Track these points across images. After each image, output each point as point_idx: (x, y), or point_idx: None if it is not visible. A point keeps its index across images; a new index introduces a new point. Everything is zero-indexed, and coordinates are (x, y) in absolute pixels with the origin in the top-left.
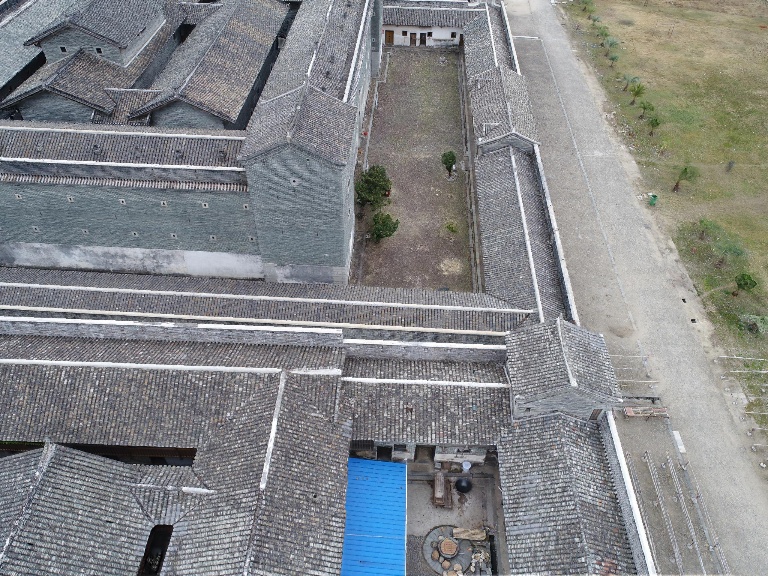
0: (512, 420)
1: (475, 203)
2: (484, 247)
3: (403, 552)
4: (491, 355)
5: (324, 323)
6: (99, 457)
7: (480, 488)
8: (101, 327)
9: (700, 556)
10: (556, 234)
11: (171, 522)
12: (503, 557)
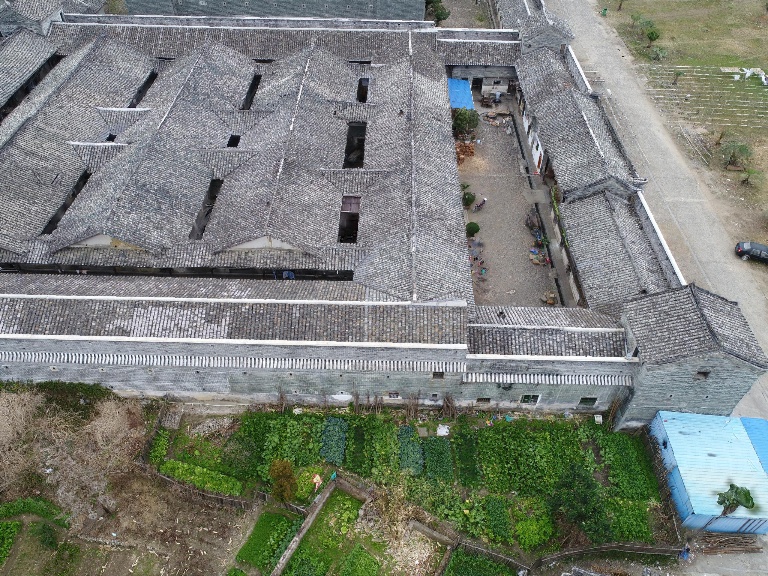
0: (522, 56)
1: (494, 14)
2: (502, 16)
3: (472, 101)
4: (510, 37)
5: None
6: (331, 52)
7: (505, 103)
8: (310, 23)
9: (614, 115)
10: (543, 4)
11: (367, 77)
12: (518, 119)
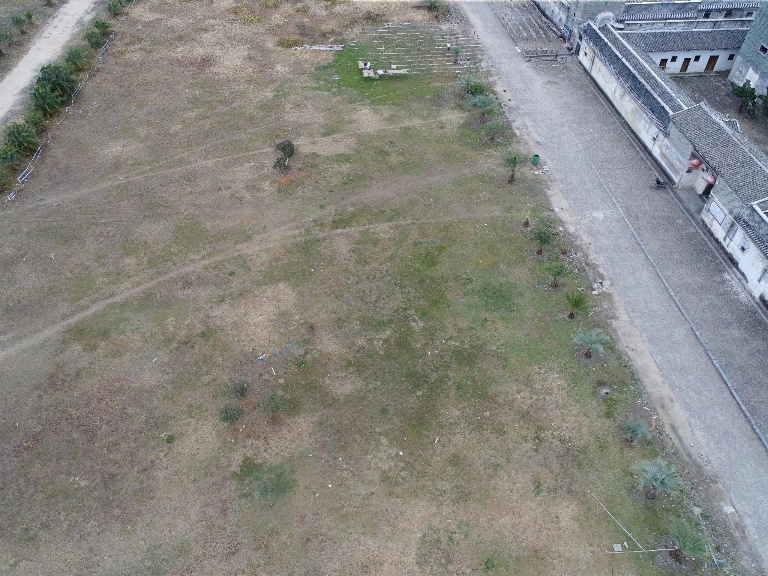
0: None
1: None
2: None
3: None
4: None
5: (718, 19)
6: None
7: None
8: None
9: None
10: None
11: None
12: None
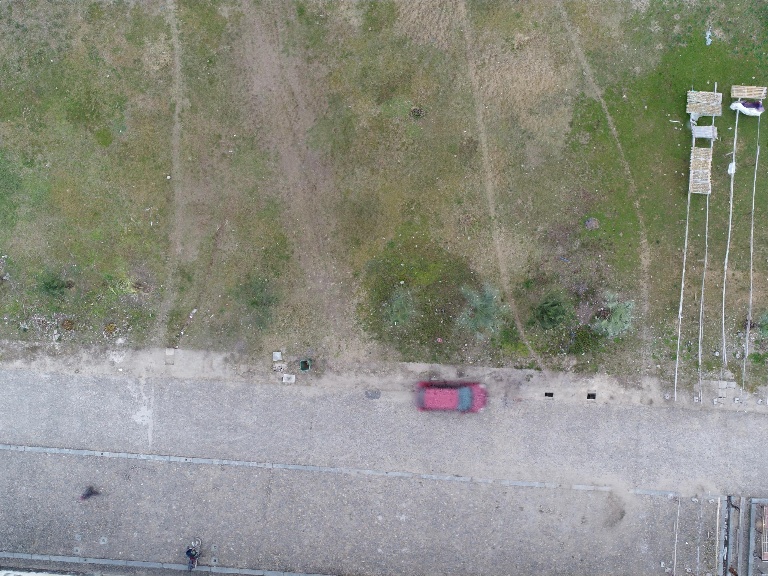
0: None
1: None
2: None
3: None
4: None
5: None
6: None
7: None
8: None
9: None
10: None
11: None
12: None
